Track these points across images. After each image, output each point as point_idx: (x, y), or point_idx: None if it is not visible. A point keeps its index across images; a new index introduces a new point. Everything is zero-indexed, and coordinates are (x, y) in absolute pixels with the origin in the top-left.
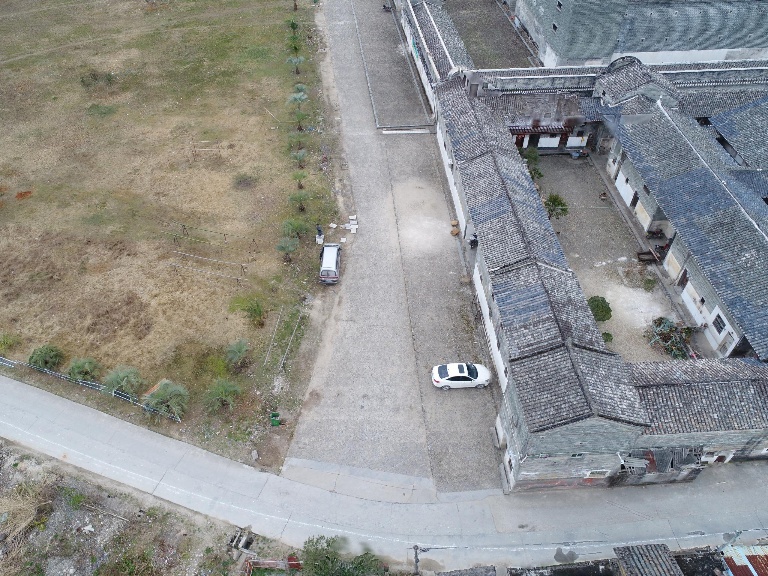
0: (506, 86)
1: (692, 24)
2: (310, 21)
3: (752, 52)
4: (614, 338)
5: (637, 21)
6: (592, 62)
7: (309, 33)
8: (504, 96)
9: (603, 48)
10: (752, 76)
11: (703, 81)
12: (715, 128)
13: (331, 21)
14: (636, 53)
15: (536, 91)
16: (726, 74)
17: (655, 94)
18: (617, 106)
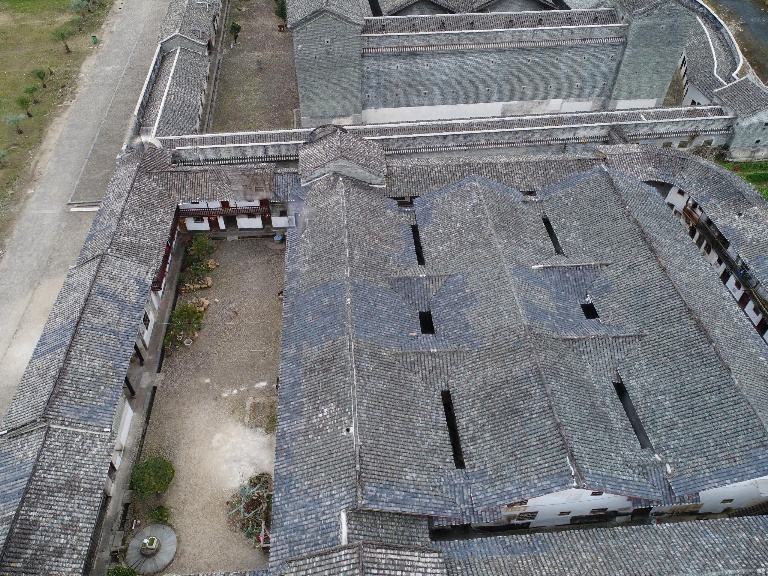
0: (209, 155)
1: (450, 76)
2: (75, 66)
3: (532, 105)
4: (187, 507)
5: (383, 74)
6: (340, 120)
7: (65, 81)
8: (211, 166)
9: (348, 105)
10: (507, 138)
11: (449, 145)
12: (414, 212)
13: (99, 66)
14: (394, 108)
15: (247, 160)
16: (474, 137)
17: (350, 171)
18: (307, 185)
